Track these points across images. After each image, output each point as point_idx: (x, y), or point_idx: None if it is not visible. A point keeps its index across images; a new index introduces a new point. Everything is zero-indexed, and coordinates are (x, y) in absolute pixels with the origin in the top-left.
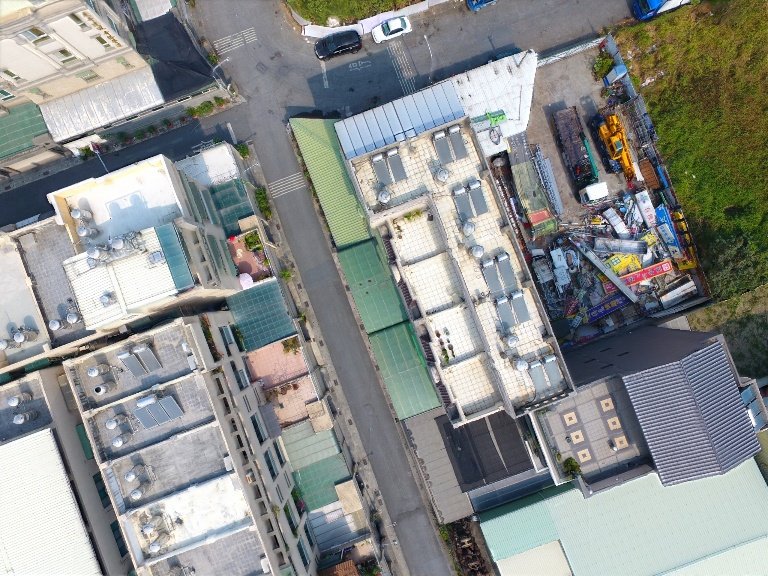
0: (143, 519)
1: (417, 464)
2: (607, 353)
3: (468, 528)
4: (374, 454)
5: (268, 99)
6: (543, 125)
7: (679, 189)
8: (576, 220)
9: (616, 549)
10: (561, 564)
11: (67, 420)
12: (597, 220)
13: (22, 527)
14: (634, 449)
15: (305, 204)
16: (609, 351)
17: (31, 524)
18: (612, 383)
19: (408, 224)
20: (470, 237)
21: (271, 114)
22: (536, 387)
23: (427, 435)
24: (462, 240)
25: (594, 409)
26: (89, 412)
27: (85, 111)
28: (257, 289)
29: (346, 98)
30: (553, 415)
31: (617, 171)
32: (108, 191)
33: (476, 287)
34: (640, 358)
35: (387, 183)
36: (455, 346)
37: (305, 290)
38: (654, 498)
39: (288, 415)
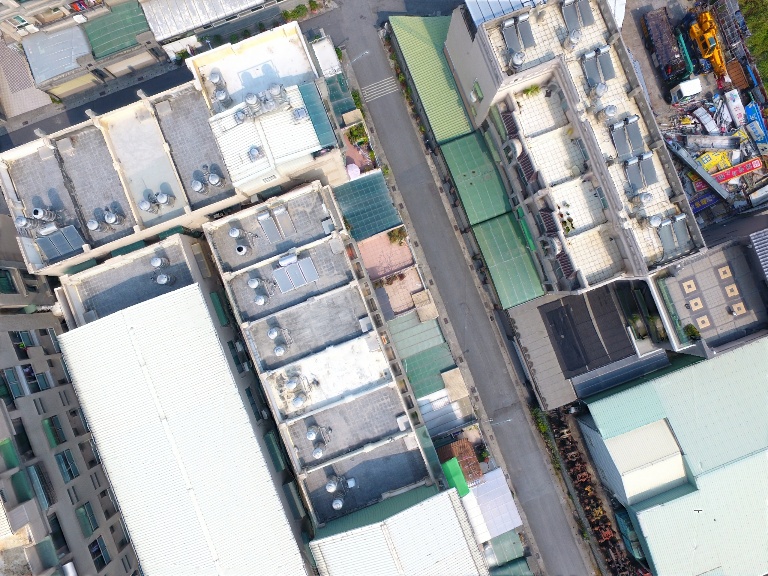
0: (280, 381)
1: (520, 353)
2: (710, 237)
3: (565, 421)
4: (470, 352)
5: (360, 5)
6: (632, 29)
7: (767, 88)
8: (665, 121)
9: (722, 425)
10: (668, 442)
11: (203, 286)
12: (687, 120)
13: (174, 377)
14: (751, 315)
15: (398, 108)
16: (711, 236)
17: (182, 375)
18: (729, 251)
19: (526, 100)
20: (598, 102)
21: (363, 19)
22: (664, 247)
23: (530, 324)
24: (590, 105)
25: (712, 277)
26: (229, 273)
27: (187, 9)
28: (363, 181)
29: (437, 3)
30: (672, 283)
31: (707, 70)
32: (241, 60)
33: (604, 151)
34: (755, 228)
35: (516, 50)
36: (574, 219)
37: (399, 192)
38: (757, 377)
39: (393, 306)
